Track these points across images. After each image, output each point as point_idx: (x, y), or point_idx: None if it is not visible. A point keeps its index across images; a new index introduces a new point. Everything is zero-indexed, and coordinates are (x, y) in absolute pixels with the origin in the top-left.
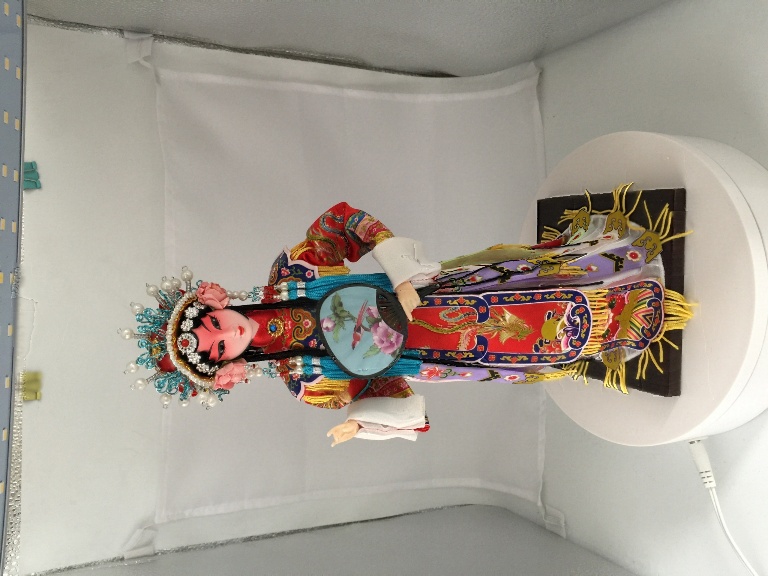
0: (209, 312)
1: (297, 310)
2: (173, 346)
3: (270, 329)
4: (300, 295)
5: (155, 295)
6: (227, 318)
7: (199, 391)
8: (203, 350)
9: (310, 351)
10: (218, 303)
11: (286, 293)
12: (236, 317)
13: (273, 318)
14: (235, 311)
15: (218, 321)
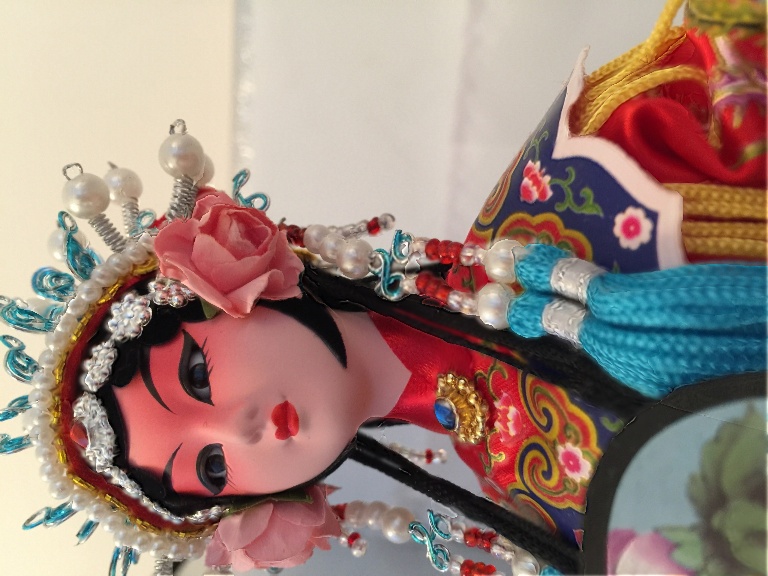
0: (197, 320)
1: (541, 383)
2: (58, 427)
3: (435, 411)
4: (557, 330)
5: (126, 206)
6: (240, 363)
7: (158, 569)
8: (145, 464)
9: (573, 564)
10: (213, 299)
11: (501, 298)
12: (281, 361)
13: (454, 371)
14: (302, 324)
15: (207, 369)
